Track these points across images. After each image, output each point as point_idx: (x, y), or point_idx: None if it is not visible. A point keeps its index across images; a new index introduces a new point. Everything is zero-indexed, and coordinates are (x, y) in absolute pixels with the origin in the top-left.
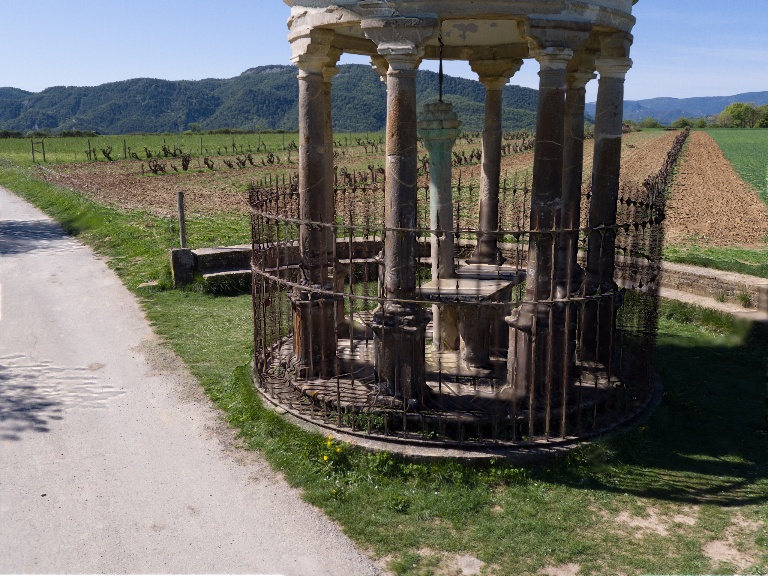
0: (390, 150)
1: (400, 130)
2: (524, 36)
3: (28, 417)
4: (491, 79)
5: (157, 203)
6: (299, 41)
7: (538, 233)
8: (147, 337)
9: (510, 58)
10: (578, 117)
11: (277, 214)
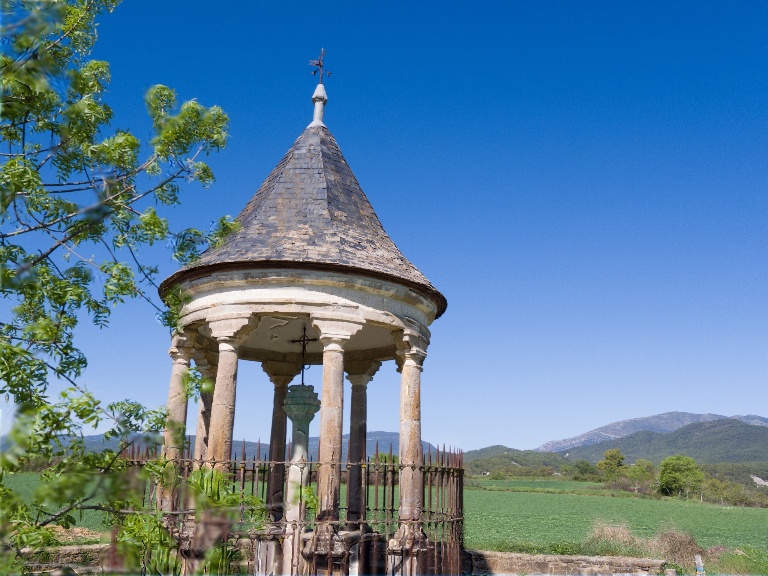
0: None
1: None
2: None
3: None
4: None
5: None
6: (345, 323)
7: None
8: None
9: None
10: None
11: None
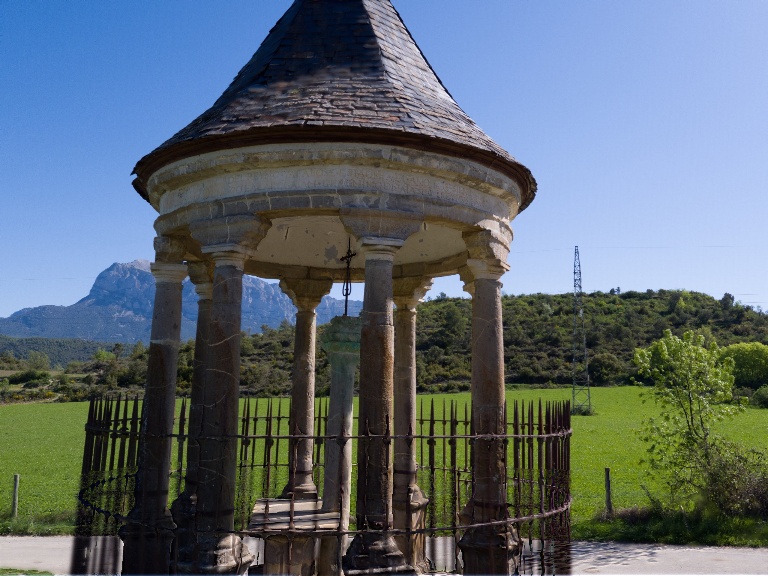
0: None
1: None
2: None
3: None
4: None
5: None
6: None
7: None
8: None
9: None
10: None
11: None
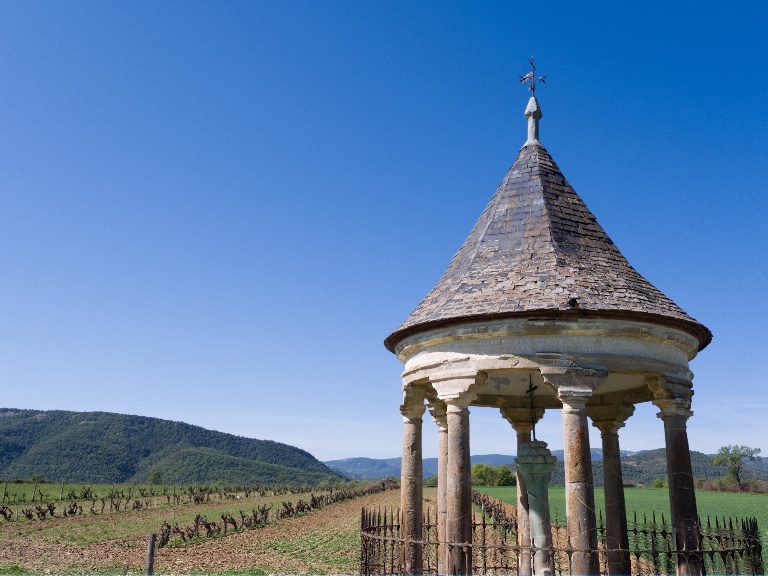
0: (575, 478)
1: (583, 460)
2: (656, 388)
3: None
4: (524, 424)
5: (1, 559)
6: (456, 381)
7: (725, 552)
8: None
9: (540, 407)
10: (618, 458)
11: (179, 567)
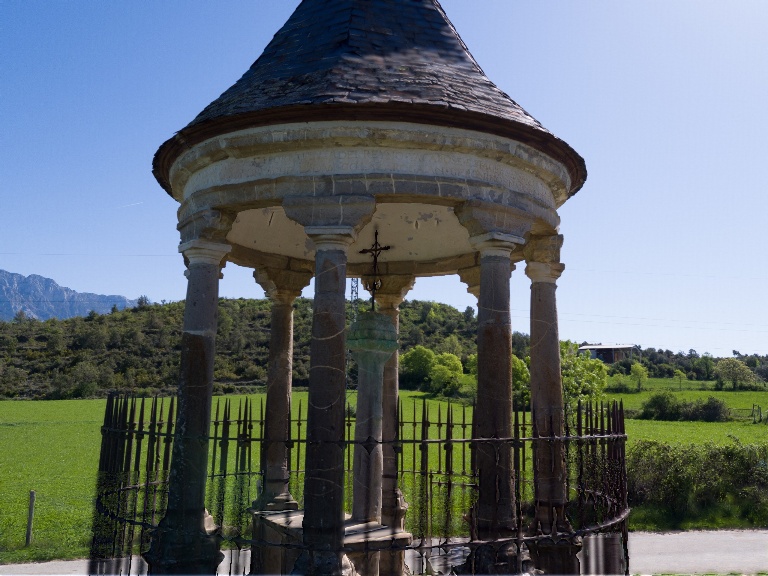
0: None
1: None
2: None
3: (443, 554)
4: None
5: None
6: None
7: None
8: (595, 574)
9: None
10: None
11: None
